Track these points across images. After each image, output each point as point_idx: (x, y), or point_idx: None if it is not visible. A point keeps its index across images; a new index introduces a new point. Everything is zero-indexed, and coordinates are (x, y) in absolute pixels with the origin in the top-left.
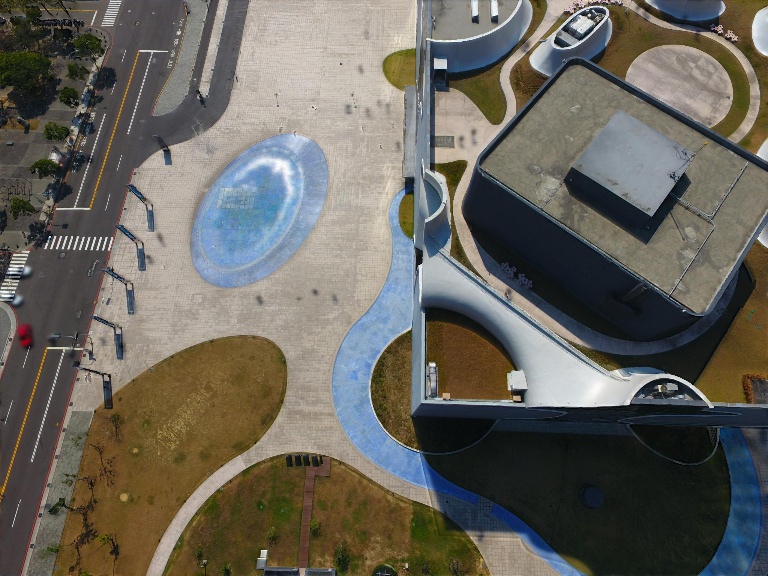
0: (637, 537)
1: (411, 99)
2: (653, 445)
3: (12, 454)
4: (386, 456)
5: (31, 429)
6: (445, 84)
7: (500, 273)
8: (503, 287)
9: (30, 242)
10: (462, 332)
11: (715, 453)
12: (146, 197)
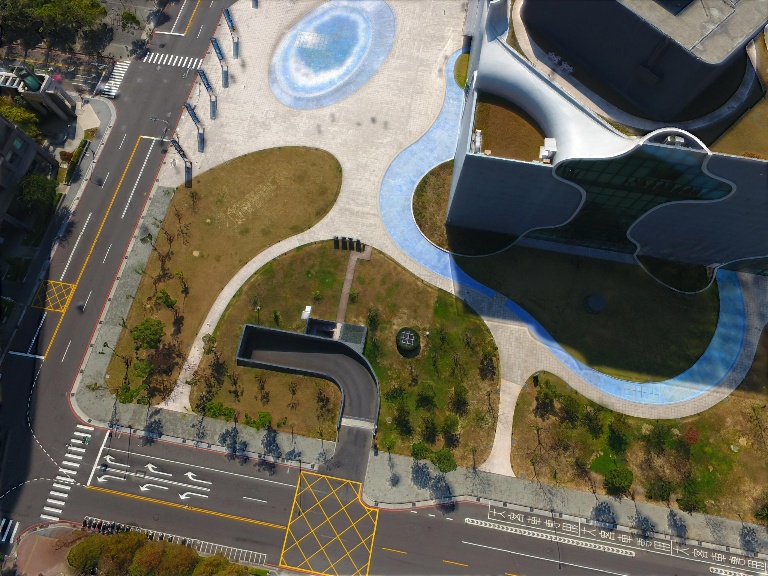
0: (629, 340)
1: None
2: (655, 273)
3: (106, 210)
4: (420, 252)
5: (123, 194)
6: None
7: (546, 60)
8: (547, 70)
9: (131, 55)
10: (506, 113)
11: (710, 287)
12: None
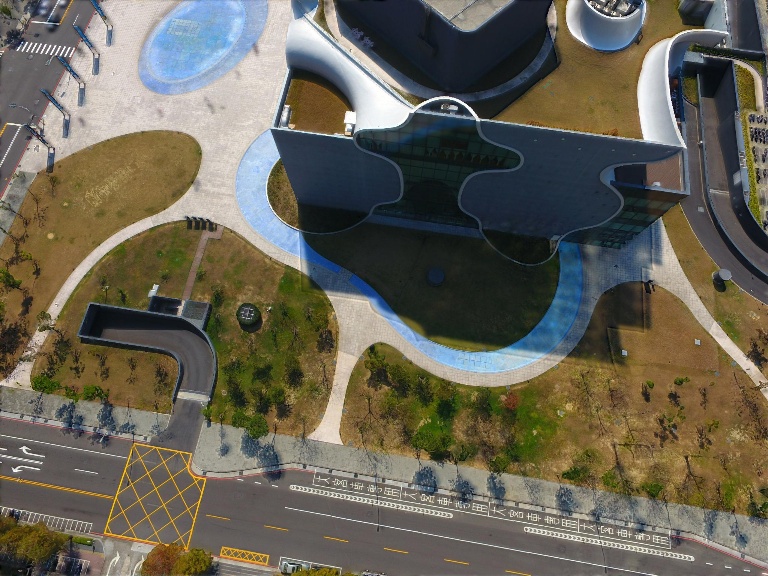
0: (468, 312)
1: None
2: (498, 246)
3: None
4: (271, 231)
5: None
6: None
7: (350, 36)
8: (350, 45)
9: (6, 45)
10: (318, 89)
11: (551, 259)
12: (108, 20)
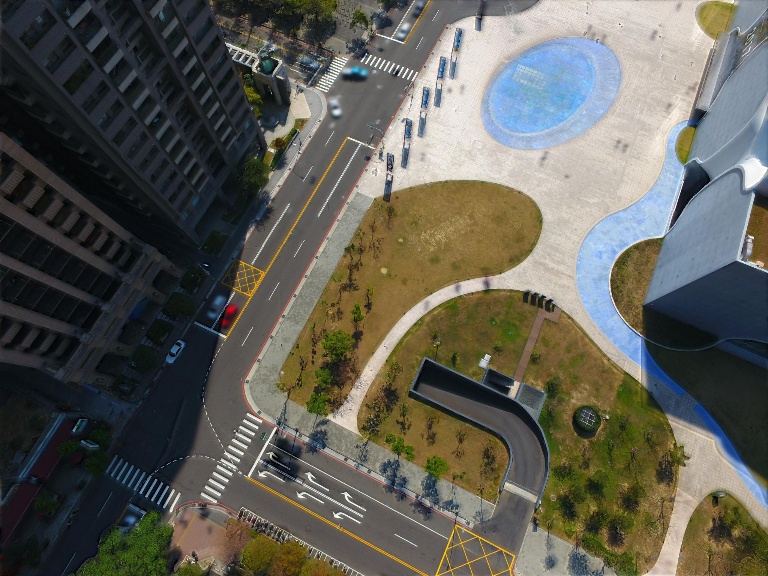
0: None
1: (722, 44)
2: None
3: (305, 205)
4: (611, 328)
5: (323, 192)
6: None
7: None
8: None
9: (350, 53)
10: None
11: None
12: None
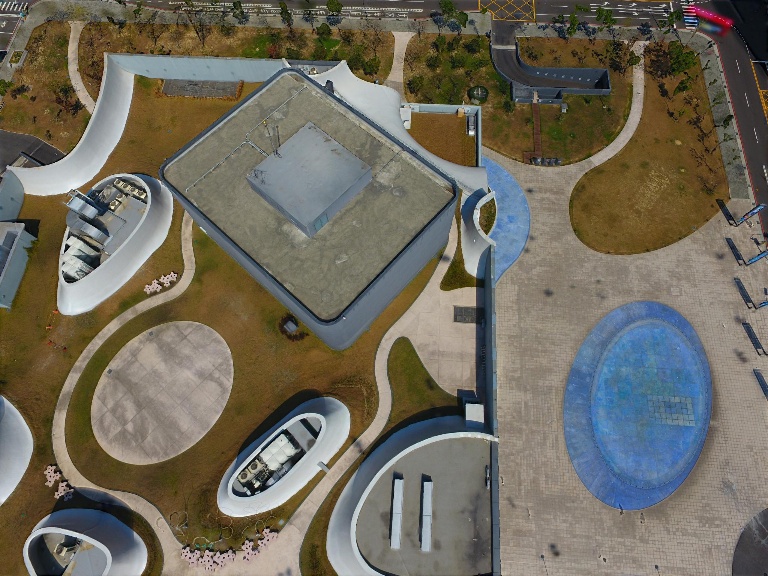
0: None
1: None
2: None
3: None
4: None
5: None
6: (463, 401)
7: None
8: None
9: None
10: (445, 157)
11: None
12: None
